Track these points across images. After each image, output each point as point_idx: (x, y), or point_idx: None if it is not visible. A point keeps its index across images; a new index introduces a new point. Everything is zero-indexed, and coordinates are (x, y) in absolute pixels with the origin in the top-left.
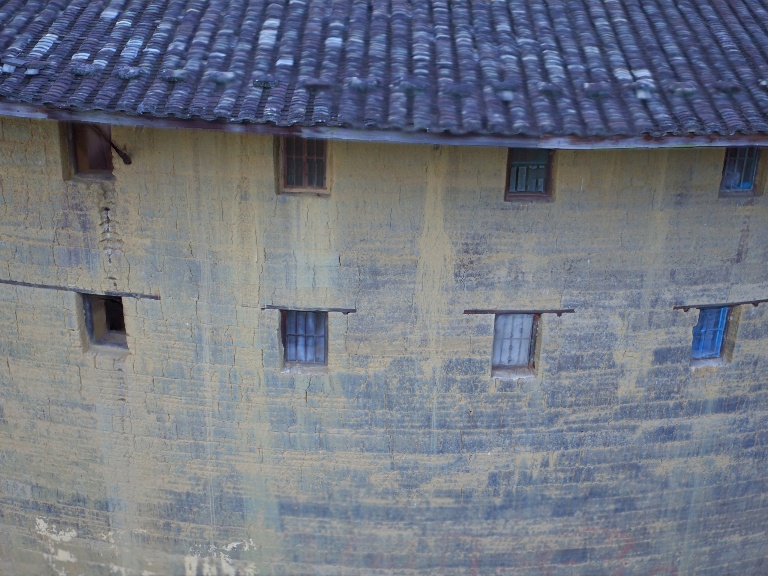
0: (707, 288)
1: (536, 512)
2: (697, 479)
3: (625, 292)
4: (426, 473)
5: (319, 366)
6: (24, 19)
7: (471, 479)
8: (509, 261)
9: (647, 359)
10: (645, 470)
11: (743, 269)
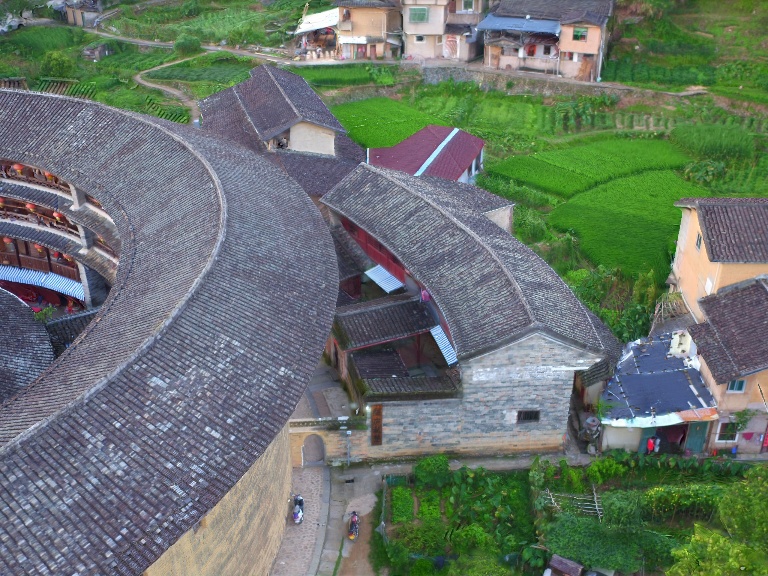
0: None
1: None
2: None
3: None
4: None
5: (200, 529)
6: (156, 489)
7: None
8: None
9: None
10: None
11: None
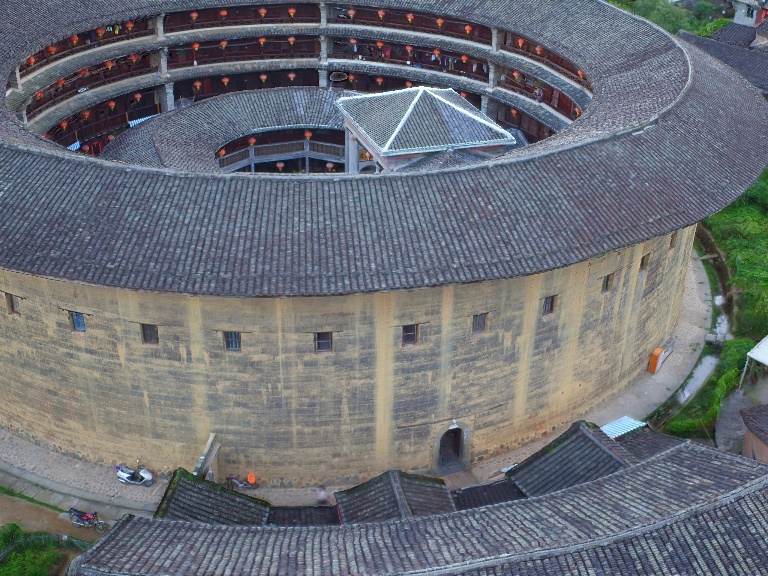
0: (68, 304)
1: (35, 370)
2: (89, 378)
3: (40, 297)
4: (0, 343)
5: None
6: None
7: (13, 350)
8: (4, 276)
9: (55, 324)
10: (67, 367)
11: (79, 300)
